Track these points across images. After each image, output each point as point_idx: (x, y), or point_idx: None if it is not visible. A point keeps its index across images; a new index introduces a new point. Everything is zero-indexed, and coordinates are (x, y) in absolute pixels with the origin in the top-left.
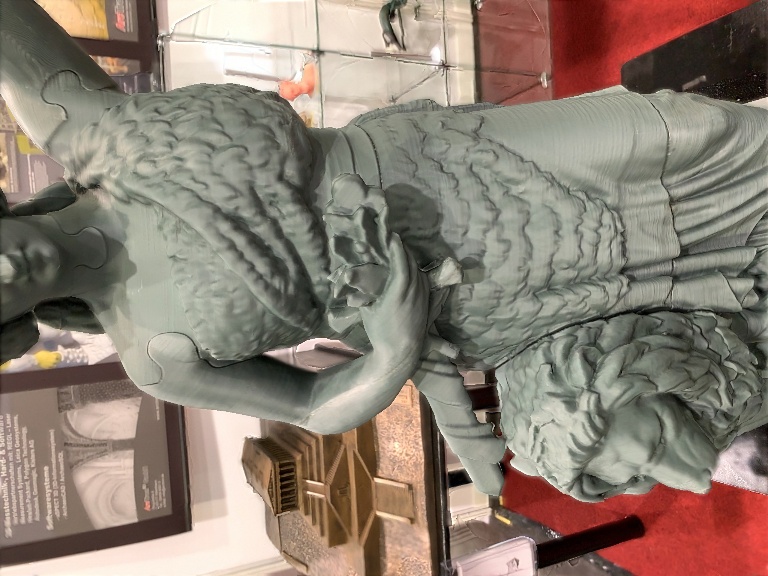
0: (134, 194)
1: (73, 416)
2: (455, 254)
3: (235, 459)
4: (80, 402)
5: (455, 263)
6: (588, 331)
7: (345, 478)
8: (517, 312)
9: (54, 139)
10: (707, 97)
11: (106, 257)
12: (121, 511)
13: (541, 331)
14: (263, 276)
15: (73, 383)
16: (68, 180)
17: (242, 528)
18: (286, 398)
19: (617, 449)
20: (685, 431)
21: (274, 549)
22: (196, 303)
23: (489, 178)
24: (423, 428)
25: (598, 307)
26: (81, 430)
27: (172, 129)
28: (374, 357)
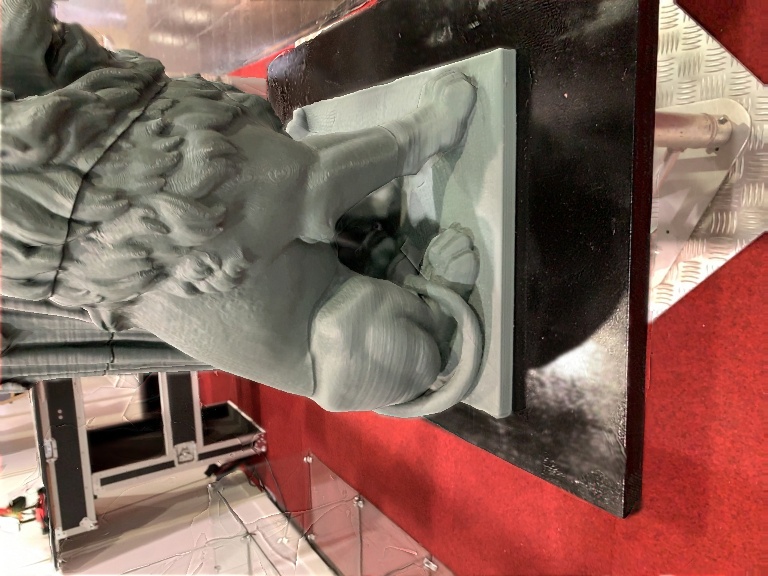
0: None
1: None
2: None
3: None
4: None
5: None
6: None
7: None
8: None
9: None
10: None
11: None
12: None
13: None
14: None
15: None
16: None
17: None
18: None
19: None
20: None
21: None
22: None
23: None
24: None
25: None
26: None
27: None
28: None
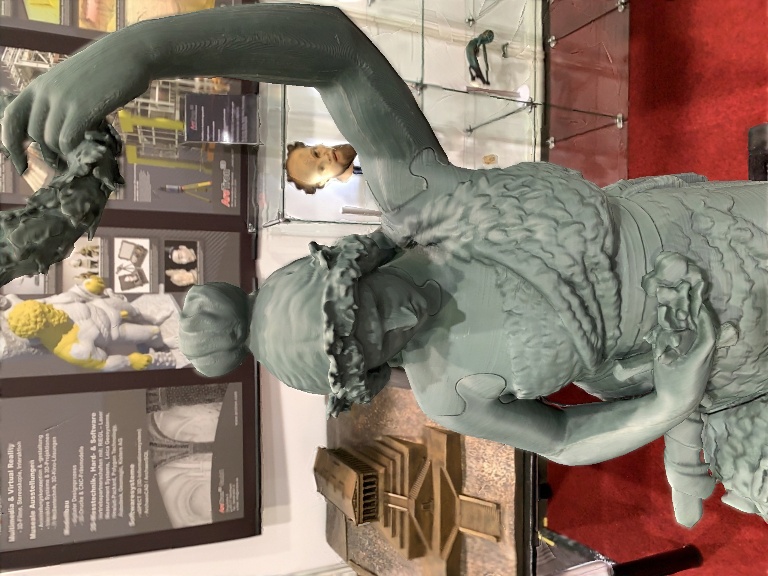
0: (482, 257)
1: (159, 417)
2: (719, 318)
3: (301, 467)
4: (166, 404)
5: (734, 329)
6: None
7: (429, 494)
8: (758, 370)
9: (409, 204)
10: None
11: (440, 306)
12: (198, 512)
13: None
14: (586, 332)
15: (161, 385)
16: (404, 237)
17: (302, 535)
18: (549, 432)
19: None
20: None
21: (337, 557)
22: (526, 352)
23: (744, 252)
24: (516, 451)
25: None
26: (166, 431)
27: (521, 204)
28: (656, 405)
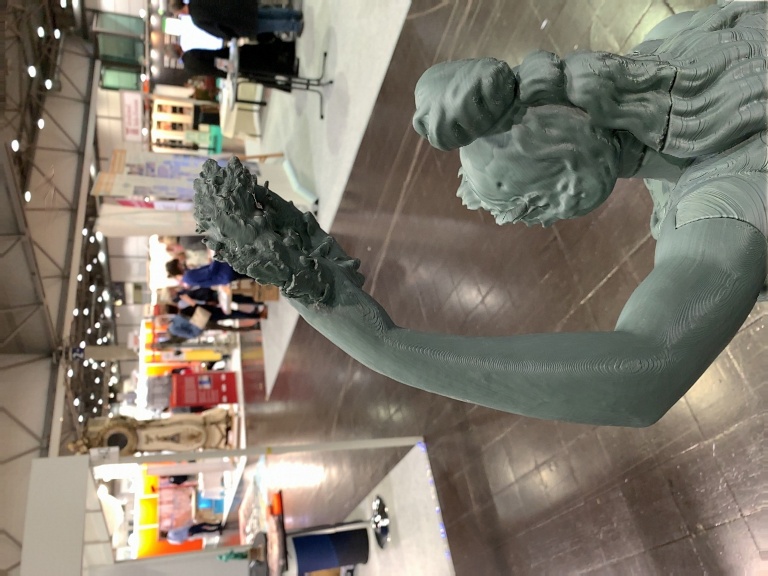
0: None
1: None
2: None
3: None
4: None
5: None
6: None
7: None
8: None
9: None
10: None
11: None
12: None
13: None
14: None
15: None
16: None
17: None
18: None
19: None
20: None
21: None
22: None
23: None
24: None
25: None
26: None
27: None
28: None
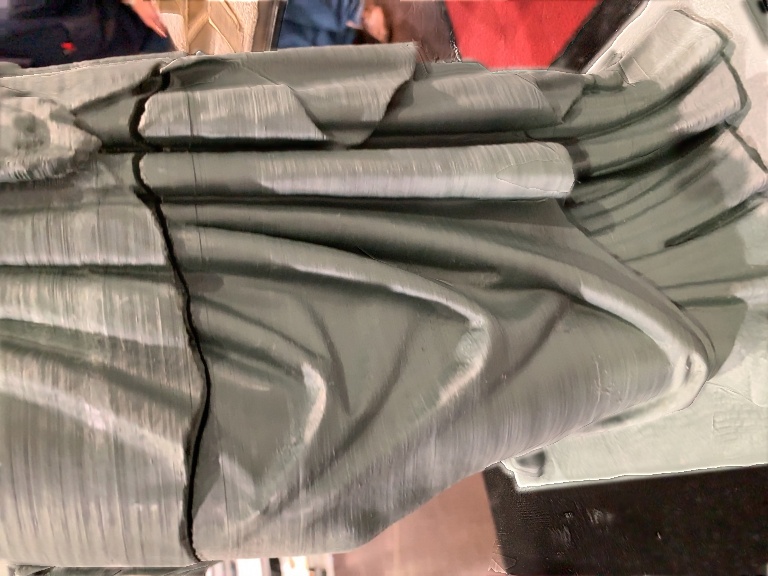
0: None
1: None
2: None
3: None
4: None
5: None
6: None
7: None
8: None
9: None
10: (443, 427)
11: None
12: None
13: None
14: None
15: None
16: None
17: None
18: None
19: None
20: None
21: None
22: None
23: None
24: None
25: None
26: None
27: None
28: None
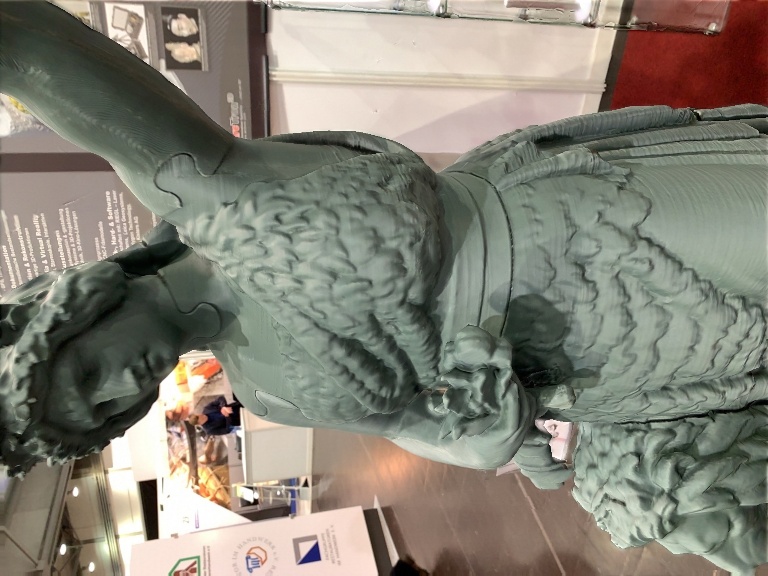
0: None
1: None
2: (572, 364)
3: None
4: None
5: (569, 396)
6: (690, 430)
7: None
8: (621, 409)
9: (168, 217)
10: None
11: (220, 328)
12: None
13: (640, 418)
14: (371, 391)
15: None
16: None
17: None
18: (377, 426)
19: (677, 540)
20: (751, 531)
21: None
22: (304, 397)
23: (635, 287)
24: None
25: (710, 408)
26: None
27: (293, 246)
28: (466, 448)
